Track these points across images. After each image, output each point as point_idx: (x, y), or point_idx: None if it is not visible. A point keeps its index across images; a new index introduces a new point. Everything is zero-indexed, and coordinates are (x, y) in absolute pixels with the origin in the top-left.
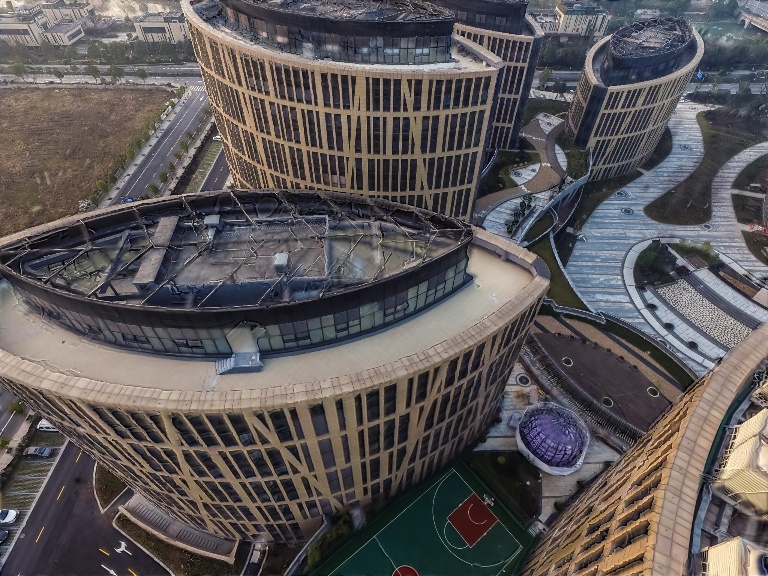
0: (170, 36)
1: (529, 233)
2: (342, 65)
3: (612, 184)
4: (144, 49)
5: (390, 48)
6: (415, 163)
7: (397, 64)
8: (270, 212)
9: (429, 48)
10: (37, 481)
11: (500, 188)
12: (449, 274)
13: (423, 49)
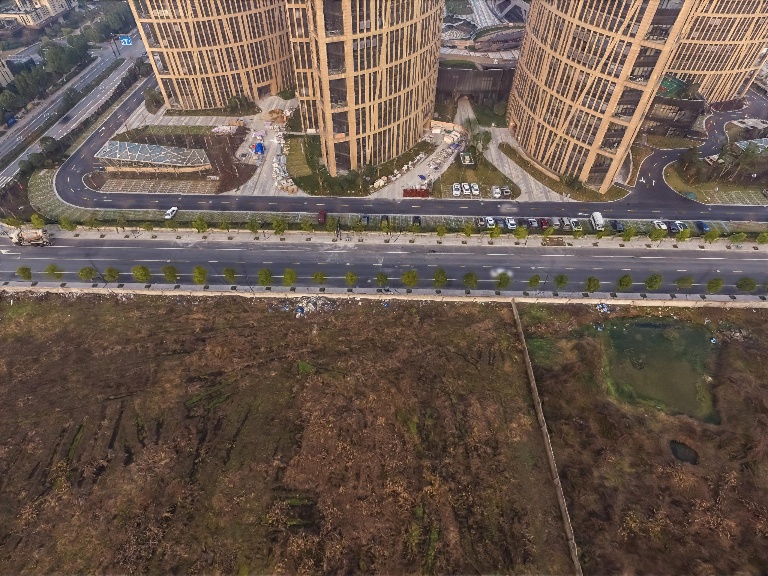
0: None
1: None
2: None
3: None
4: None
5: None
6: None
7: None
8: None
9: None
10: (632, 223)
11: None
12: None
13: None
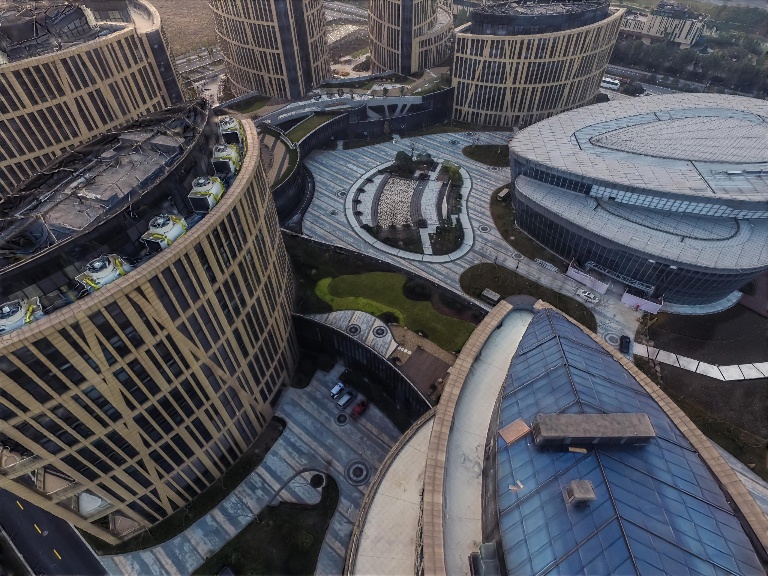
0: None
1: None
2: None
3: (471, 126)
4: None
5: None
6: (244, 25)
7: None
8: None
9: None
10: None
11: (355, 87)
12: (111, 16)
13: None
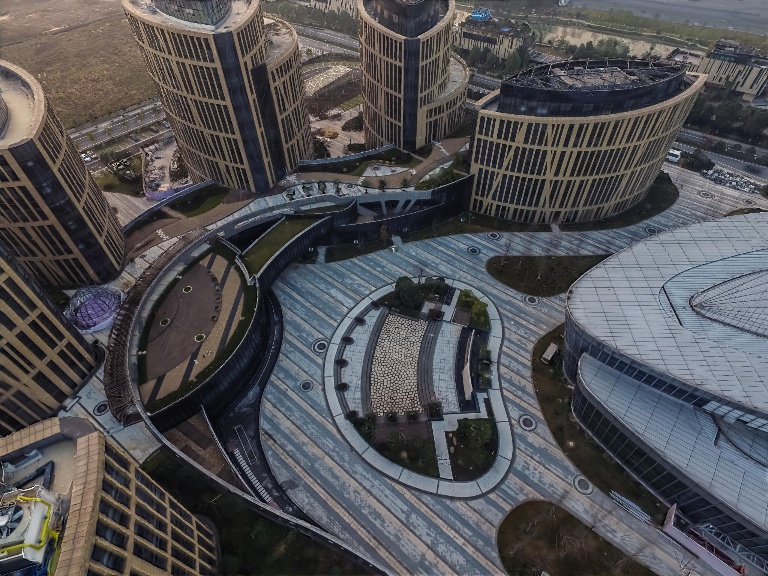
0: (330, 7)
1: (312, 210)
2: (136, 9)
3: (496, 224)
4: (301, 12)
5: (173, 5)
6: (187, 100)
7: (180, 19)
8: (3, 77)
9: (193, 10)
10: None
11: (342, 172)
12: None
13: (189, 10)
